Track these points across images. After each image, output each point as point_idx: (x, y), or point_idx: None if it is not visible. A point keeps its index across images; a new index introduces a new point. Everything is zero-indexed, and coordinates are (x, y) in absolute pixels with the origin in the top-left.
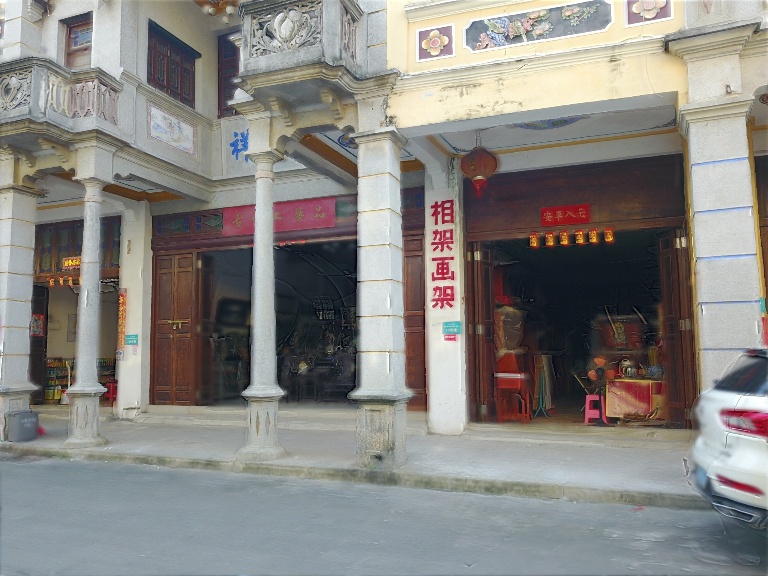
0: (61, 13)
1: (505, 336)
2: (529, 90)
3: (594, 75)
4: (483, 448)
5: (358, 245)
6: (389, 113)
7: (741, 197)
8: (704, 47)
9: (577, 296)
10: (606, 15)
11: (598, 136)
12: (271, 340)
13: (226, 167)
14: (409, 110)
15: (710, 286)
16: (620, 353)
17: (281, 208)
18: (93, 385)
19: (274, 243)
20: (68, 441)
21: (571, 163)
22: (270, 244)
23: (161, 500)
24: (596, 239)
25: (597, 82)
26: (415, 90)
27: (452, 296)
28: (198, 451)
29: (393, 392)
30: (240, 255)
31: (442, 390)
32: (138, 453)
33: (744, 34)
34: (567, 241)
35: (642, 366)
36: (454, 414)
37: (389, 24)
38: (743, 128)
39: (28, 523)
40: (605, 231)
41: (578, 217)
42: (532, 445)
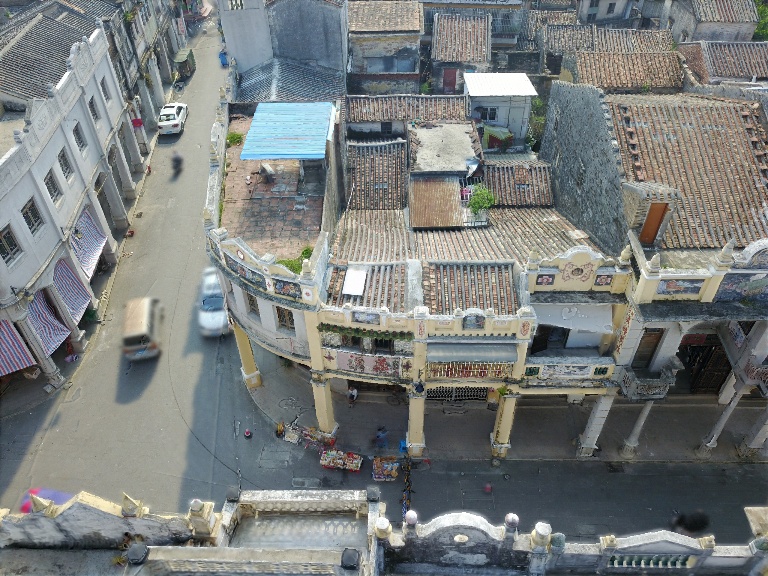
0: (649, 326)
1: None
2: None
3: None
4: (748, 418)
5: None
6: None
7: None
8: None
9: None
10: None
11: None
12: None
13: None
14: None
15: None
16: None
17: None
18: (637, 441)
19: None
20: (627, 457)
21: None
22: None
23: (719, 497)
24: None
25: None
26: None
27: None
28: (672, 449)
29: (763, 446)
30: None
31: (729, 393)
32: (656, 456)
33: None
34: None
35: None
36: (730, 399)
37: None
38: None
39: (718, 524)
40: None
41: None
42: (759, 411)
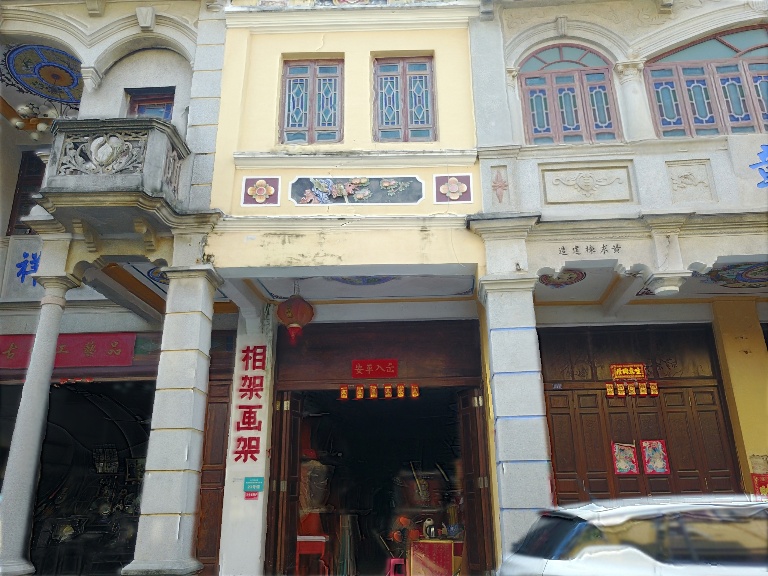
0: None
1: (311, 493)
2: (349, 246)
3: (407, 241)
4: None
5: (157, 387)
6: (207, 251)
7: (532, 362)
8: (498, 229)
9: (385, 451)
10: (418, 191)
11: (407, 297)
12: (29, 500)
13: (6, 289)
14: (229, 251)
15: (509, 445)
16: (424, 512)
17: (69, 340)
18: None
19: (54, 380)
20: None
21: (382, 319)
22: (47, 381)
23: None
24: (404, 394)
25: (410, 247)
26: (237, 232)
27: (258, 448)
28: None
29: (180, 564)
30: (6, 392)
31: (238, 558)
32: None
33: (528, 223)
34: (377, 395)
35: (445, 525)
36: None
37: (216, 167)
38: (531, 301)
39: None
40: (412, 387)
41: (388, 371)
42: None
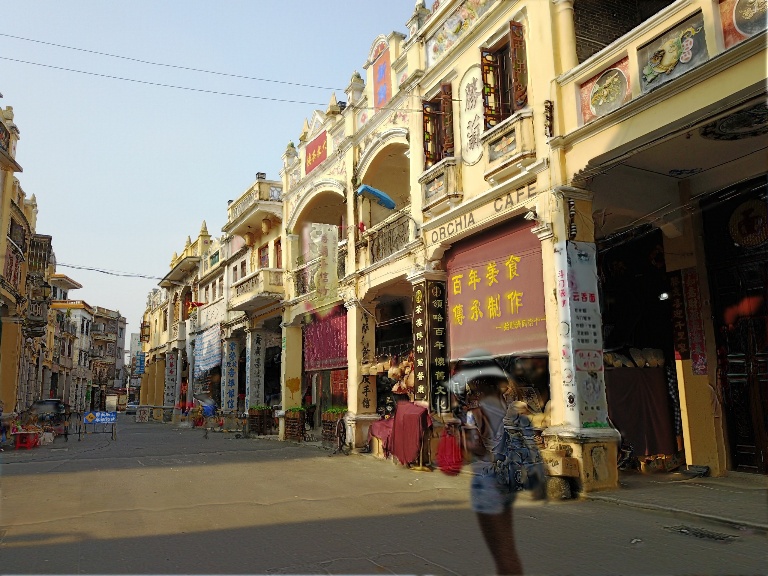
0: None
1: None
2: None
3: None
4: None
5: None
6: None
7: None
8: None
9: None
10: None
11: None
12: None
13: None
14: None
15: None
16: None
17: None
18: None
19: None
20: None
21: None
22: None
23: None
24: None
25: None
26: None
27: None
28: None
29: None
30: None
31: None
32: None
33: None
34: None
35: None
36: None
37: None
38: None
39: None
40: None
41: None
42: None
